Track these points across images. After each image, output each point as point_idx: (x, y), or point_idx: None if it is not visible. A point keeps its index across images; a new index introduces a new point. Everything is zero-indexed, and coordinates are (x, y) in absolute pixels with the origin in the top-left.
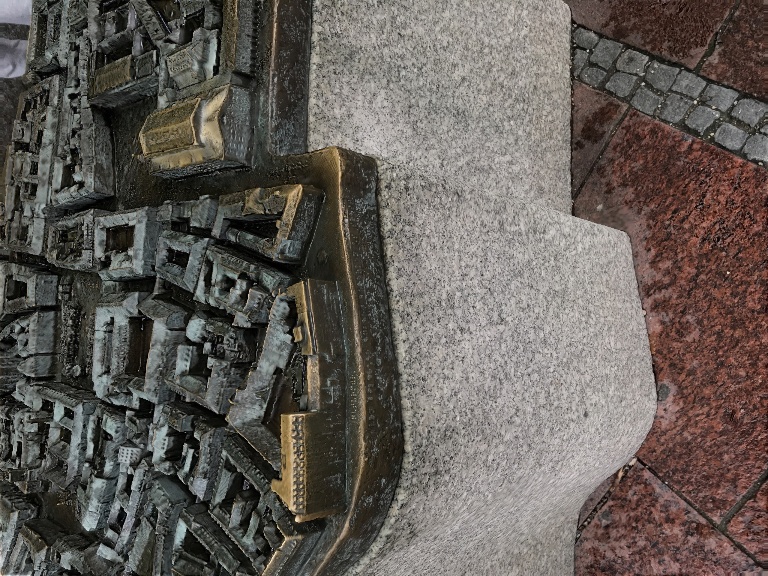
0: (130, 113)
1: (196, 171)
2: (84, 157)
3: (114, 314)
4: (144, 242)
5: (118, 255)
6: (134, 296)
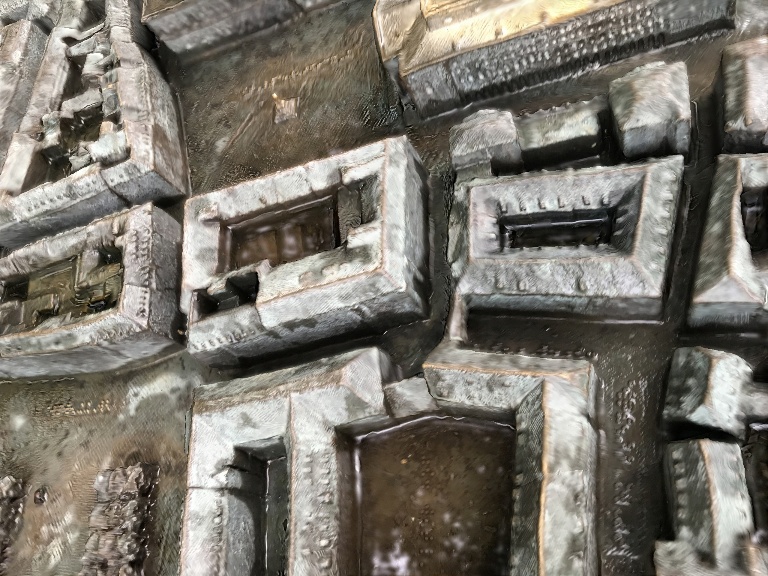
0: (234, 53)
1: (552, 55)
2: (126, 109)
3: (293, 417)
4: (404, 212)
5: (287, 265)
6: (369, 357)
